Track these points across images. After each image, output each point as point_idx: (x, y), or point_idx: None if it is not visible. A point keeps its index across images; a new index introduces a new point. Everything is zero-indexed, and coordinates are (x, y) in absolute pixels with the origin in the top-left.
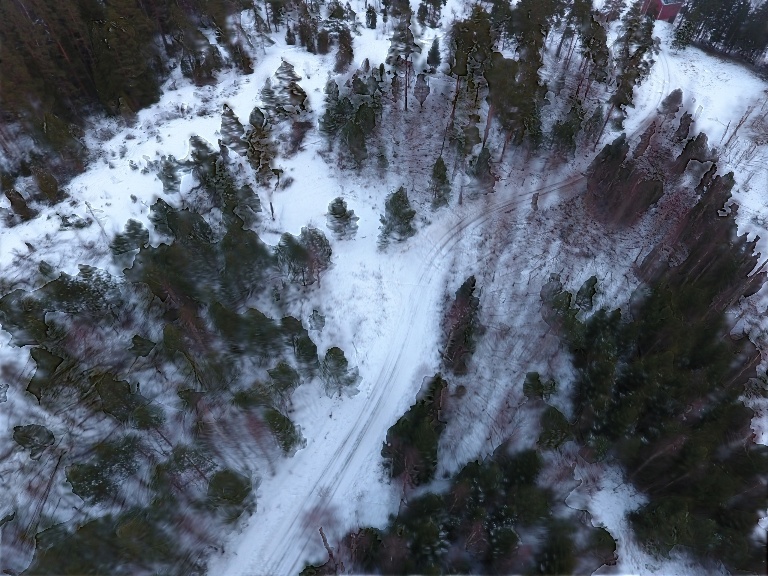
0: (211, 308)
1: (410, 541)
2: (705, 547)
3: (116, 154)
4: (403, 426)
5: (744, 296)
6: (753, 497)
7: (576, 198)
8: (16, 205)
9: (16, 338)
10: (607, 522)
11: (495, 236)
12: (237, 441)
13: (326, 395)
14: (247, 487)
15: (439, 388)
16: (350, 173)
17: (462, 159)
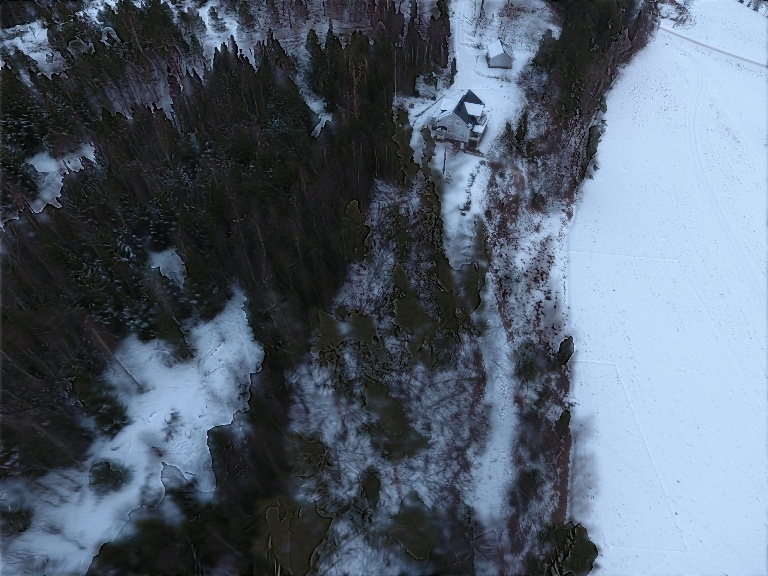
0: (142, 30)
1: (210, 73)
2: (341, 97)
3: (99, 5)
4: (216, 51)
5: (441, 66)
6: (369, 88)
7: (364, 31)
8: (48, 17)
9: (55, 45)
10: (315, 108)
11: (306, 39)
12: (149, 60)
13: (194, 65)
14: (152, 68)
15: (235, 45)
16: (231, 15)
17: (289, 2)
